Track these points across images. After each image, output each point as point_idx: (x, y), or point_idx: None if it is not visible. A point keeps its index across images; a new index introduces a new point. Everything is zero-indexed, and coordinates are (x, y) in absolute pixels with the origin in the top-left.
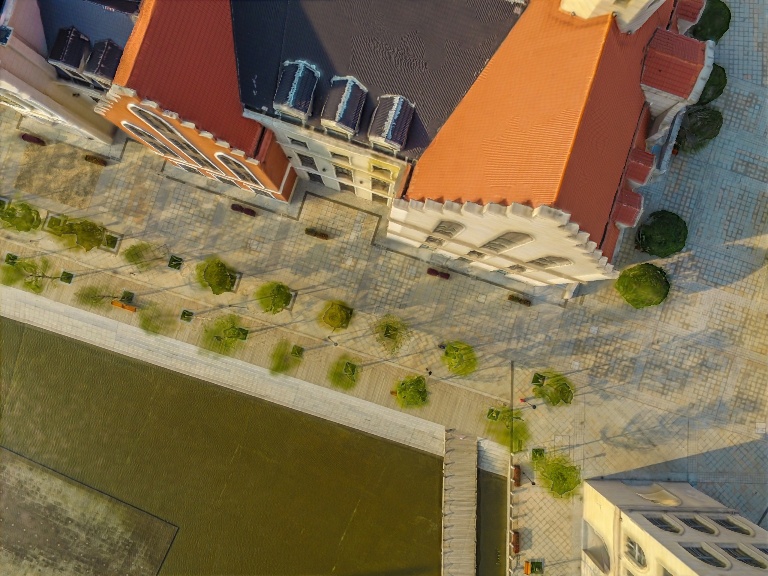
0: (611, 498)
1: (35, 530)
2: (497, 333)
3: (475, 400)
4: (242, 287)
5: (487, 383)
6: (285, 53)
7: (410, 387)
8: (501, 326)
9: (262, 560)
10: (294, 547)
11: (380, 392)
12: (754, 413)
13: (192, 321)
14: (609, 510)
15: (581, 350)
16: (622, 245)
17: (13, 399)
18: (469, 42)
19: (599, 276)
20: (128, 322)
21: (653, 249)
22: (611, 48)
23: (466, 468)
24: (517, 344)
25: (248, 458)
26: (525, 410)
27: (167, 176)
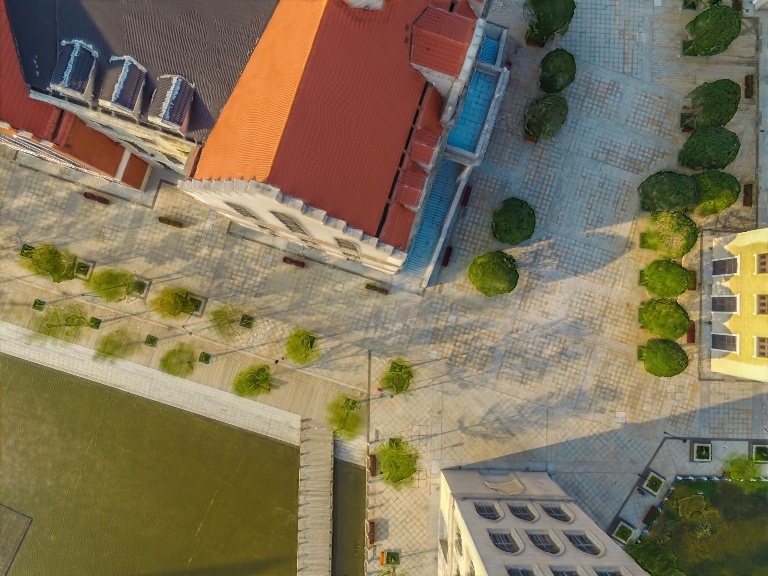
0: (454, 487)
1: None
2: (354, 322)
3: (331, 389)
4: (95, 276)
5: (344, 372)
6: (60, 32)
7: (248, 375)
8: (358, 315)
9: (117, 552)
10: (150, 538)
11: (235, 382)
12: (614, 402)
13: (44, 310)
14: (449, 499)
15: (439, 339)
16: (481, 233)
17: None
18: (237, 21)
19: (393, 259)
20: None
21: (501, 236)
22: (337, 22)
23: (322, 458)
24: (374, 333)
25: (103, 449)
26: (382, 399)
27: (20, 164)
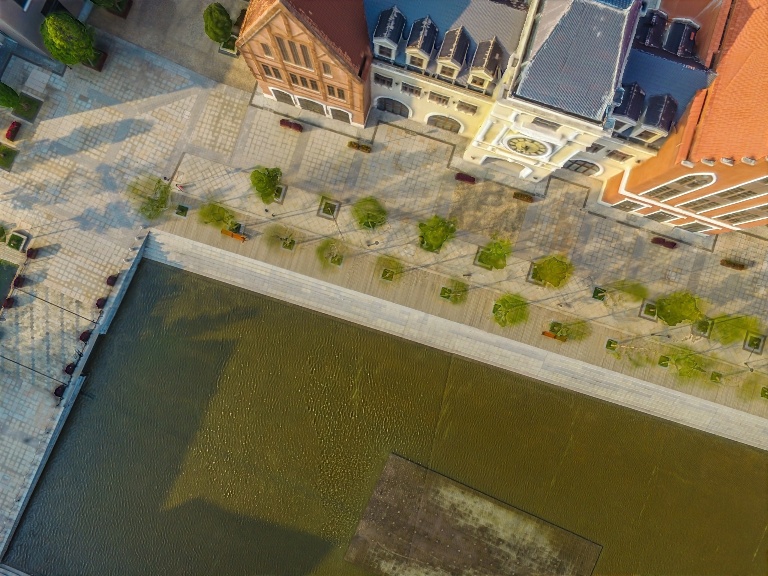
0: None
1: (469, 551)
2: None
3: None
4: None
5: None
6: None
7: None
8: None
9: None
10: (711, 564)
11: None
12: None
13: (616, 350)
14: None
15: None
16: None
17: (443, 426)
18: None
19: None
20: (557, 351)
21: None
22: None
23: None
24: None
25: (664, 479)
26: None
27: (589, 211)
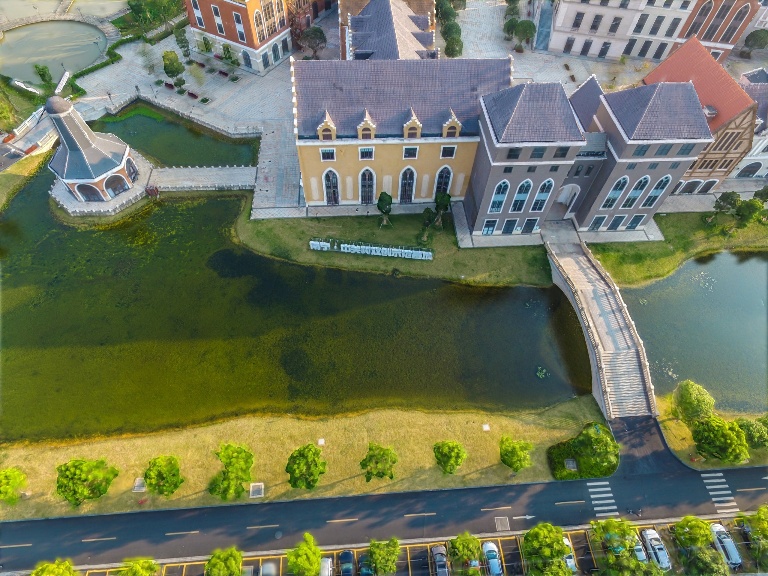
0: None
1: None
2: None
3: None
4: None
5: None
6: None
7: None
8: None
9: None
10: None
11: None
12: None
13: None
14: None
15: None
16: None
17: None
18: None
19: None
20: None
21: None
22: None
23: None
24: None
25: None
26: None
27: None
